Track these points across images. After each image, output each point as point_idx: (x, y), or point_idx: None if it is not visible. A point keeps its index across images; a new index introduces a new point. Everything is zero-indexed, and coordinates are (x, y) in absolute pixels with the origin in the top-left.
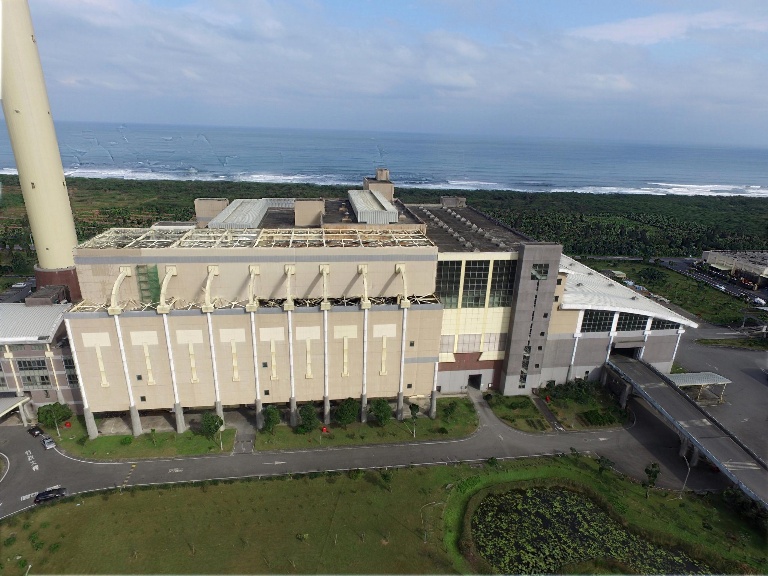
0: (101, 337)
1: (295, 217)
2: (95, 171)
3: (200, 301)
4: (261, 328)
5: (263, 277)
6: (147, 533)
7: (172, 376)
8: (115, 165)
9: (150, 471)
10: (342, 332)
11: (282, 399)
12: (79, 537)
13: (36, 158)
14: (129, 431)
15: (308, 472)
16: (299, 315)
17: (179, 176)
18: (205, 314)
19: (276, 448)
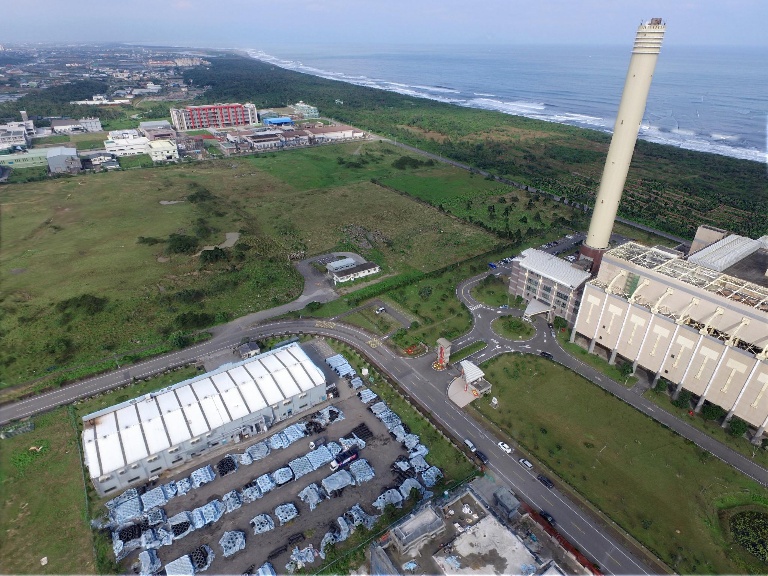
0: (596, 300)
1: (767, 269)
2: (658, 137)
3: (654, 304)
4: (680, 335)
5: (700, 307)
6: (574, 393)
7: (619, 335)
8: (678, 134)
9: (587, 371)
10: (734, 364)
11: (674, 380)
12: (551, 377)
13: (611, 188)
14: (587, 349)
15: (663, 423)
16: (708, 340)
17: (736, 153)
18: (651, 313)
19: (654, 402)
